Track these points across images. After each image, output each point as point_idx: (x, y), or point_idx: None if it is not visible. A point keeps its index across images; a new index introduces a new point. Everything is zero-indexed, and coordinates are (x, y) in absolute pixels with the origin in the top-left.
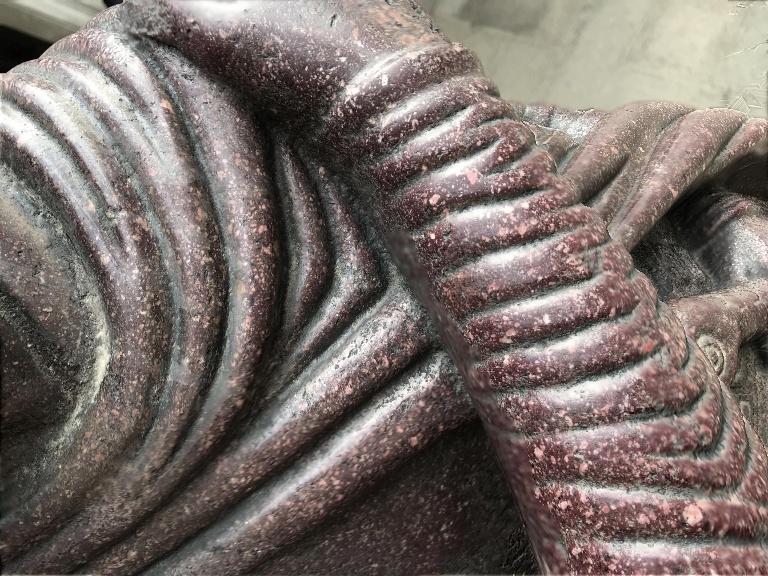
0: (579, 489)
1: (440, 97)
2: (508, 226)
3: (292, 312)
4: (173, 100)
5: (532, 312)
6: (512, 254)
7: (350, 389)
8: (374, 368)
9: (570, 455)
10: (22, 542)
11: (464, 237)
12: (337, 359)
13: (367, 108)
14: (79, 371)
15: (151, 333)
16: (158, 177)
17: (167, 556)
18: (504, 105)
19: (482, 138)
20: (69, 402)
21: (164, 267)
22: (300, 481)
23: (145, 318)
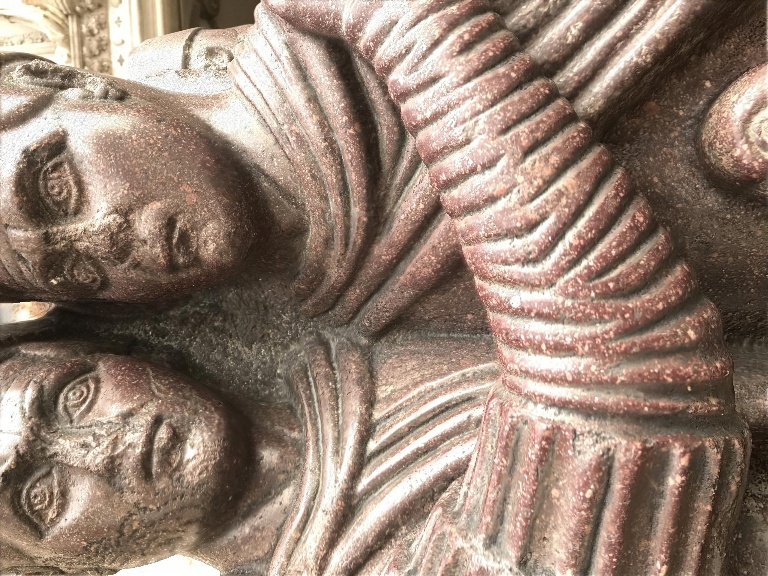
0: (476, 280)
1: (381, 20)
2: (421, 113)
3: (384, 161)
4: (290, 48)
5: (438, 172)
6: (427, 132)
7: (422, 205)
8: (432, 191)
9: (468, 260)
10: (309, 285)
11: (406, 122)
12: (414, 186)
13: (352, 38)
14: (305, 205)
15: (315, 188)
16: (292, 102)
17: (376, 292)
18: (434, 0)
19: (405, 46)
20: (308, 220)
21: (311, 151)
22: (417, 257)
23: (310, 181)
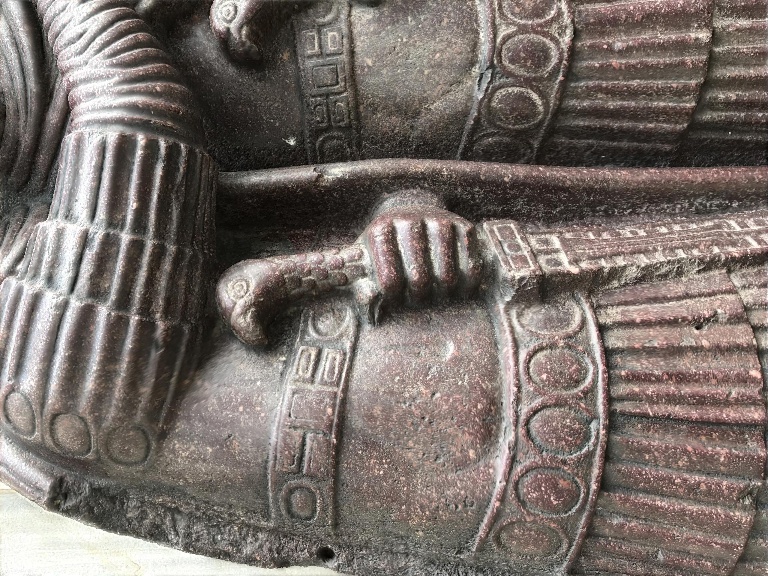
0: None
1: None
2: None
3: (46, 51)
4: None
5: None
6: None
7: None
8: None
9: None
10: (8, 154)
11: None
12: None
13: None
14: None
15: (3, 72)
16: None
17: (54, 157)
18: None
19: None
20: None
21: (1, 47)
22: None
23: None
